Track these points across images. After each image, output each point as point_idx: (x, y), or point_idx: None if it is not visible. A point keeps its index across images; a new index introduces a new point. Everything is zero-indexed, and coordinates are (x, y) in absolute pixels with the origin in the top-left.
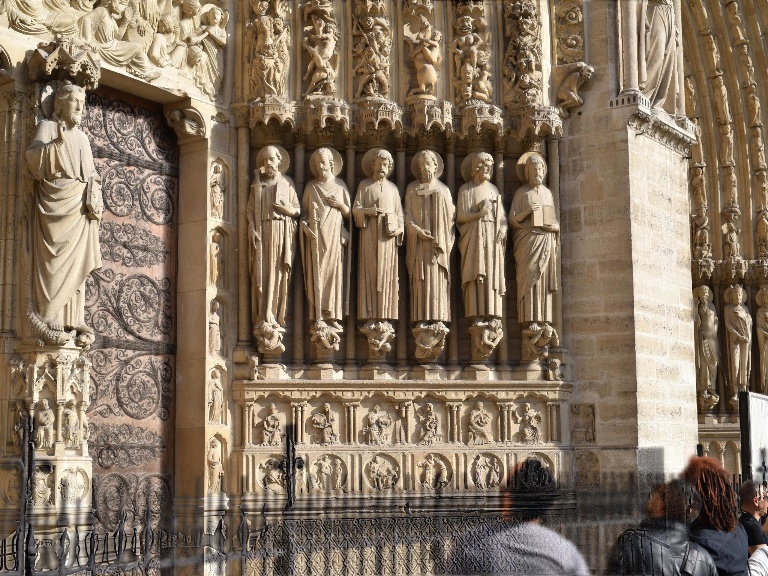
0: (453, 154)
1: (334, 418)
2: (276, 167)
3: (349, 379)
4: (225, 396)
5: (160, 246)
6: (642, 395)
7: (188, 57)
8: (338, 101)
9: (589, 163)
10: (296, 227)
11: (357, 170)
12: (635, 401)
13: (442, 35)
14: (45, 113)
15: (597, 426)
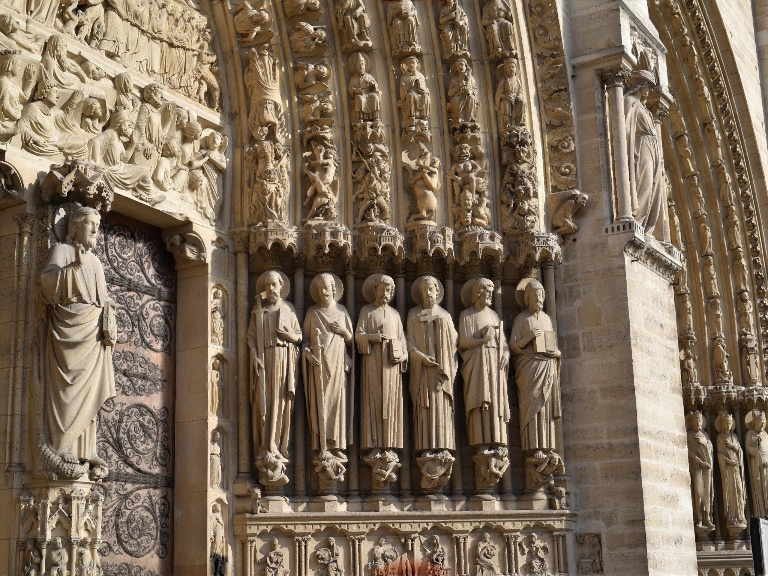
0: (452, 280)
1: (339, 552)
2: (278, 293)
3: (354, 511)
4: (226, 531)
5: (158, 374)
6: (649, 523)
7: (189, 181)
8: (340, 226)
9: (586, 289)
10: (298, 354)
11: (356, 296)
12: (643, 530)
13: (440, 162)
14: (58, 236)
15: (604, 556)
